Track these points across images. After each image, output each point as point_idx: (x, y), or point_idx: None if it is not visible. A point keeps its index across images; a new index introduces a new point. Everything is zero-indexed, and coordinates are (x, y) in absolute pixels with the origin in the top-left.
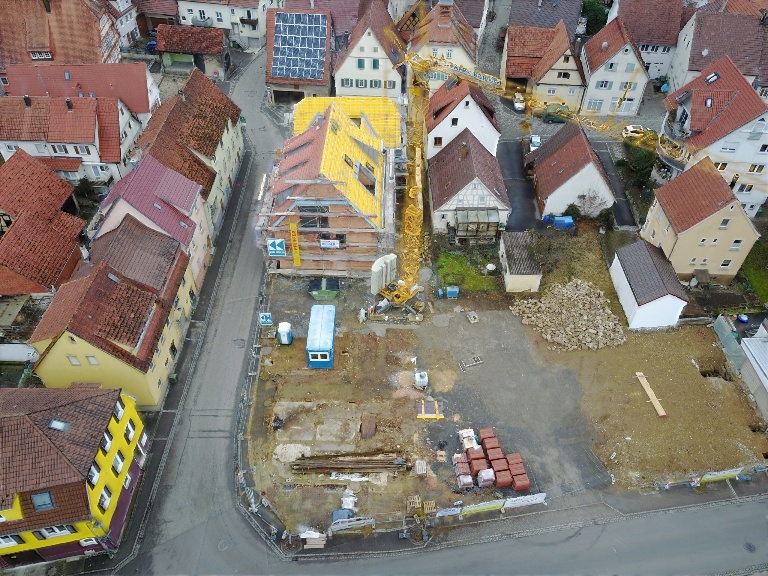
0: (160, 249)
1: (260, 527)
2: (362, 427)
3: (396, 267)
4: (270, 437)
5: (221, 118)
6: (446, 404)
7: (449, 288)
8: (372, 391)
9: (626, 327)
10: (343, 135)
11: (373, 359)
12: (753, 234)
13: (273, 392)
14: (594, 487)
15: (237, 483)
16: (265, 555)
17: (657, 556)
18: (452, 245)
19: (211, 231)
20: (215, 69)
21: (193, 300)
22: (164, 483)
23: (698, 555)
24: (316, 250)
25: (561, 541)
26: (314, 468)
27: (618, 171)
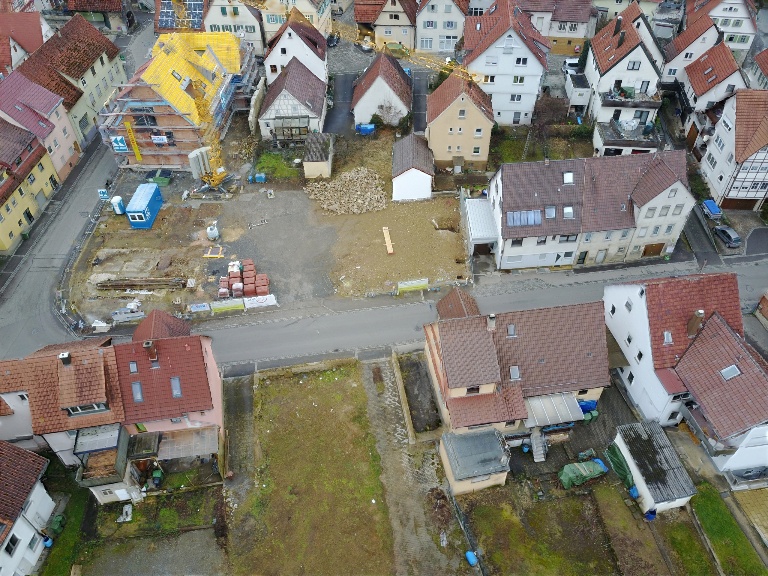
0: (17, 138)
1: (65, 321)
2: (159, 263)
3: (225, 164)
4: (89, 270)
5: (94, 52)
6: (228, 249)
7: (257, 174)
8: (176, 242)
9: (390, 199)
10: (177, 57)
11: (184, 222)
12: (487, 123)
13: (100, 243)
14: (319, 296)
15: (56, 297)
16: (64, 336)
17: (347, 334)
18: (274, 148)
19: (79, 139)
20: (119, 25)
21: (56, 187)
22: (3, 297)
23: (378, 333)
24: (153, 147)
25: (281, 327)
26: (113, 285)
27: (429, 92)
